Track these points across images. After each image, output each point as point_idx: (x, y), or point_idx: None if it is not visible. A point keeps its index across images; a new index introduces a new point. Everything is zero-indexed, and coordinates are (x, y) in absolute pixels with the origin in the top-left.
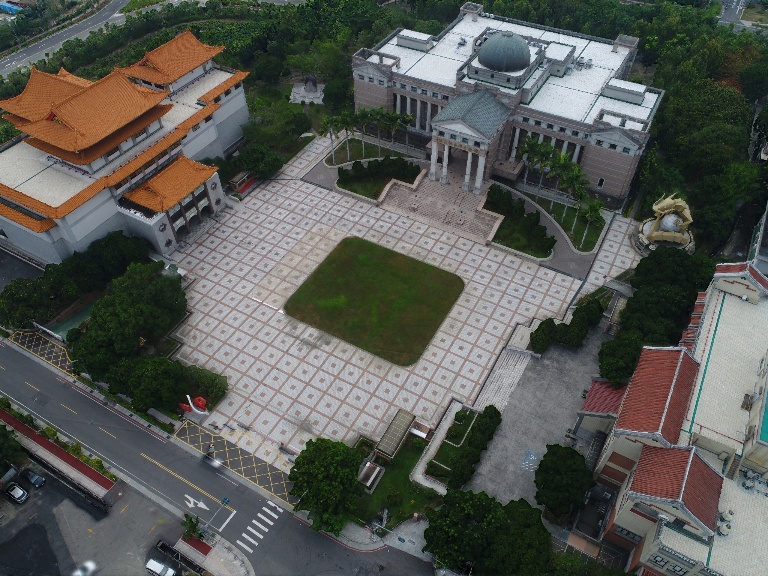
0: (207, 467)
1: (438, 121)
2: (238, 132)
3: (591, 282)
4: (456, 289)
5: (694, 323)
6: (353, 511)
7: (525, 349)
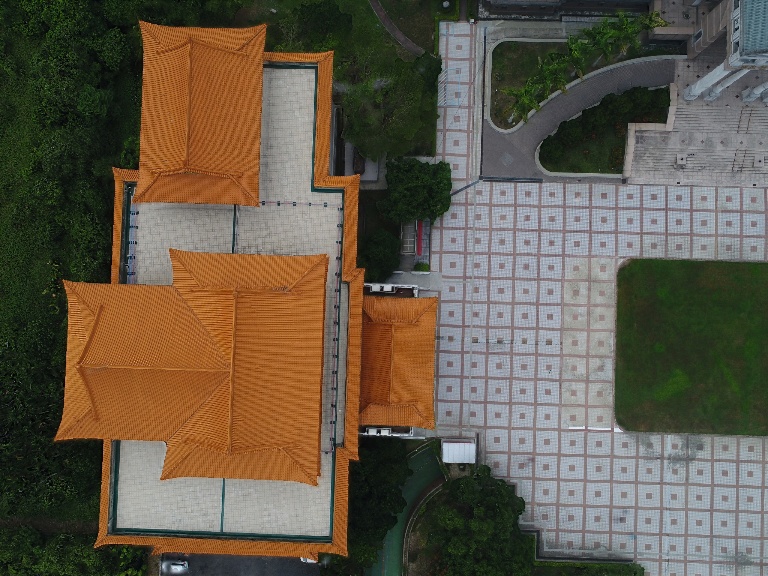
0: None
1: (761, 53)
2: (331, 137)
3: None
4: None
5: None
6: None
7: None
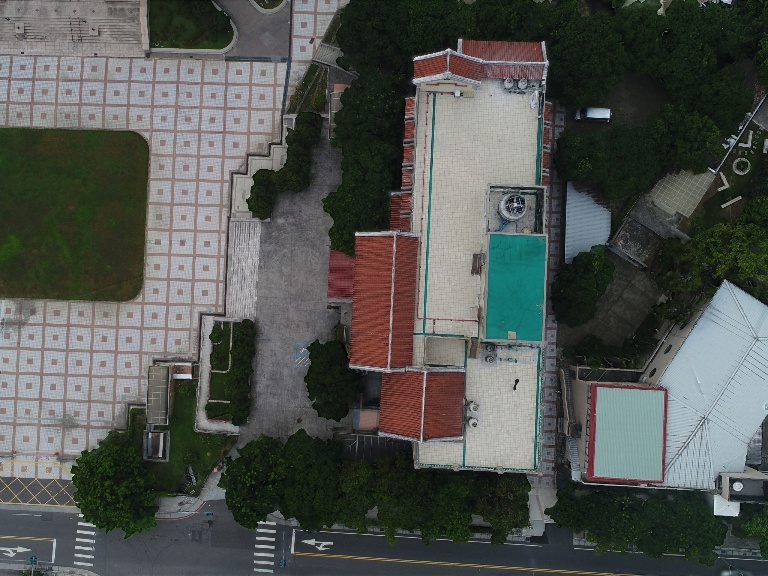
0: (0, 513)
1: None
2: None
3: (297, 59)
4: (140, 156)
5: (407, 158)
6: (160, 485)
7: (252, 212)
